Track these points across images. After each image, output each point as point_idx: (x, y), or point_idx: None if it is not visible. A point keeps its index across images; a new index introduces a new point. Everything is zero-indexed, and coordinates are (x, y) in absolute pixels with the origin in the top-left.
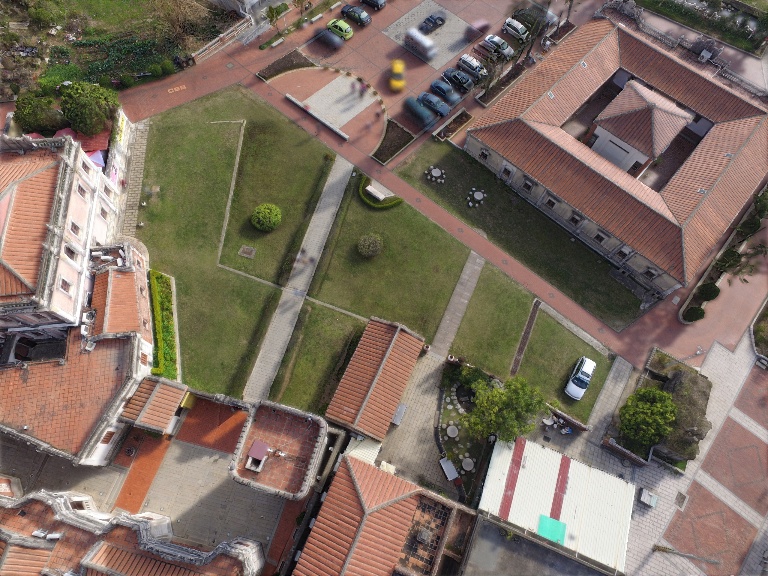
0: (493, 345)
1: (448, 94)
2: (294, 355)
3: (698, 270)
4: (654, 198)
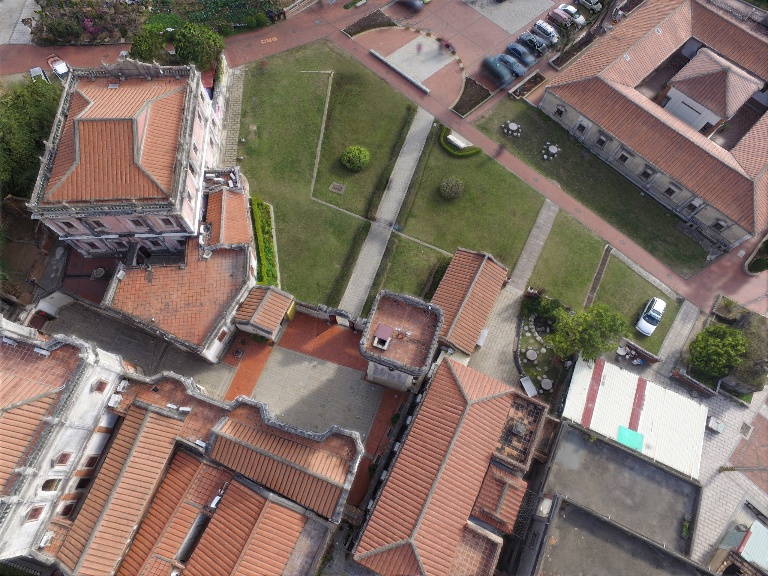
0: (567, 283)
1: (523, 56)
2: (383, 280)
3: (763, 228)
4: (725, 155)
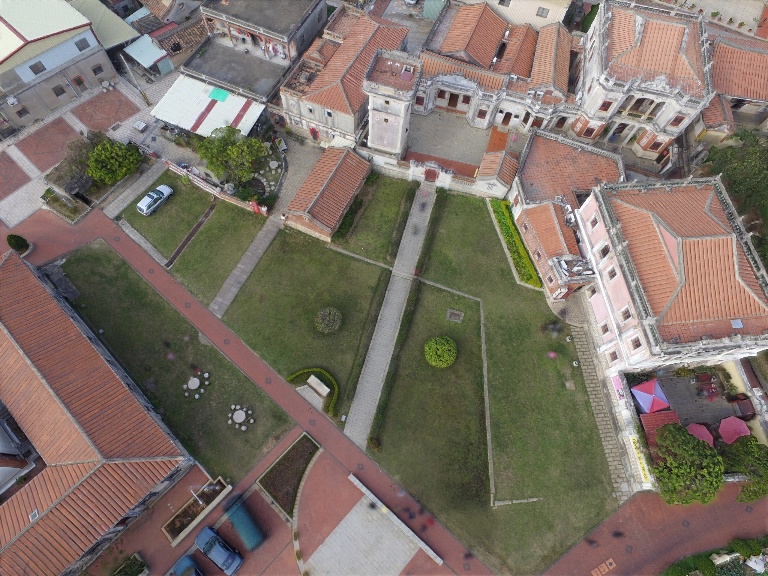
0: (224, 229)
1: (191, 571)
2: None
3: None
4: None
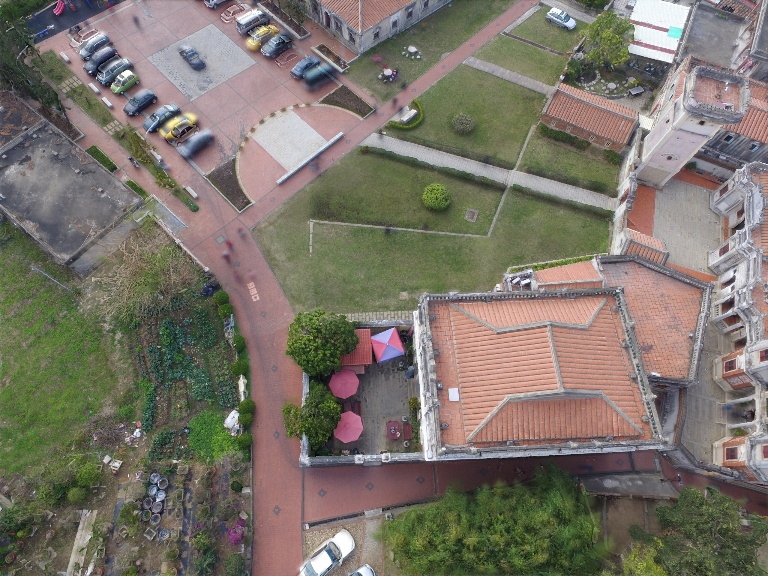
0: (541, 61)
1: (296, 54)
2: None
3: None
4: None
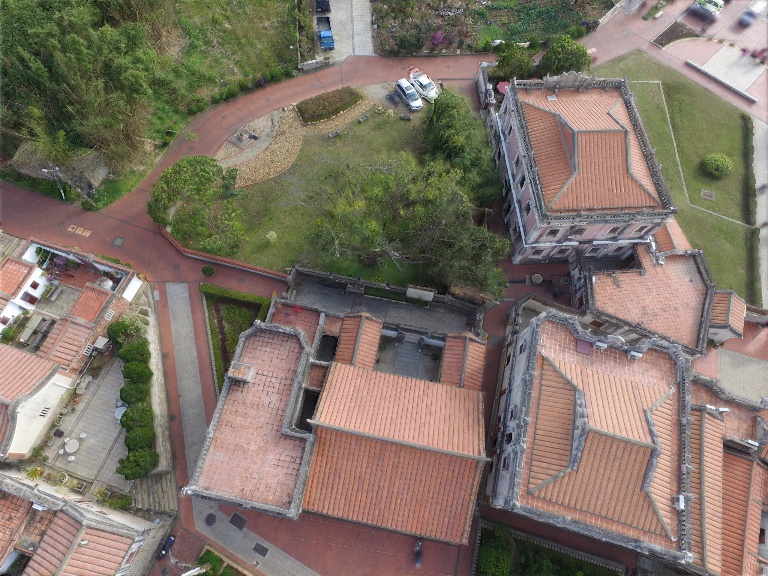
0: None
1: None
2: None
3: None
4: None
